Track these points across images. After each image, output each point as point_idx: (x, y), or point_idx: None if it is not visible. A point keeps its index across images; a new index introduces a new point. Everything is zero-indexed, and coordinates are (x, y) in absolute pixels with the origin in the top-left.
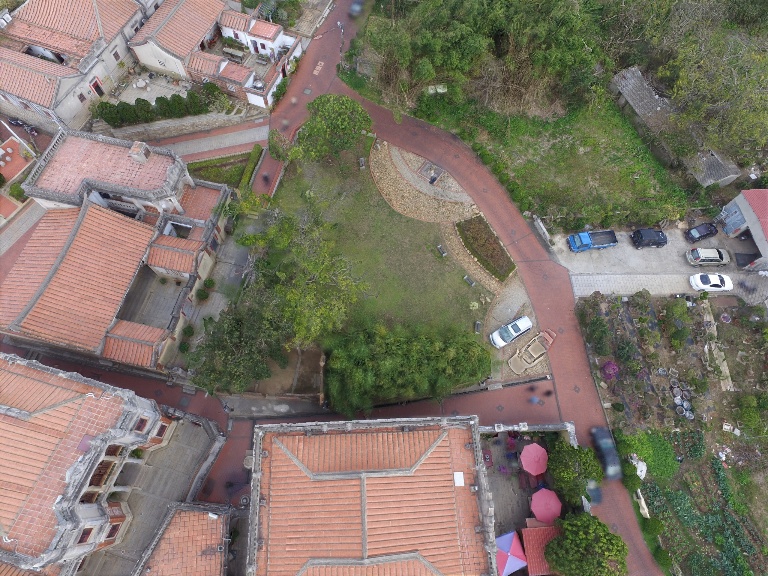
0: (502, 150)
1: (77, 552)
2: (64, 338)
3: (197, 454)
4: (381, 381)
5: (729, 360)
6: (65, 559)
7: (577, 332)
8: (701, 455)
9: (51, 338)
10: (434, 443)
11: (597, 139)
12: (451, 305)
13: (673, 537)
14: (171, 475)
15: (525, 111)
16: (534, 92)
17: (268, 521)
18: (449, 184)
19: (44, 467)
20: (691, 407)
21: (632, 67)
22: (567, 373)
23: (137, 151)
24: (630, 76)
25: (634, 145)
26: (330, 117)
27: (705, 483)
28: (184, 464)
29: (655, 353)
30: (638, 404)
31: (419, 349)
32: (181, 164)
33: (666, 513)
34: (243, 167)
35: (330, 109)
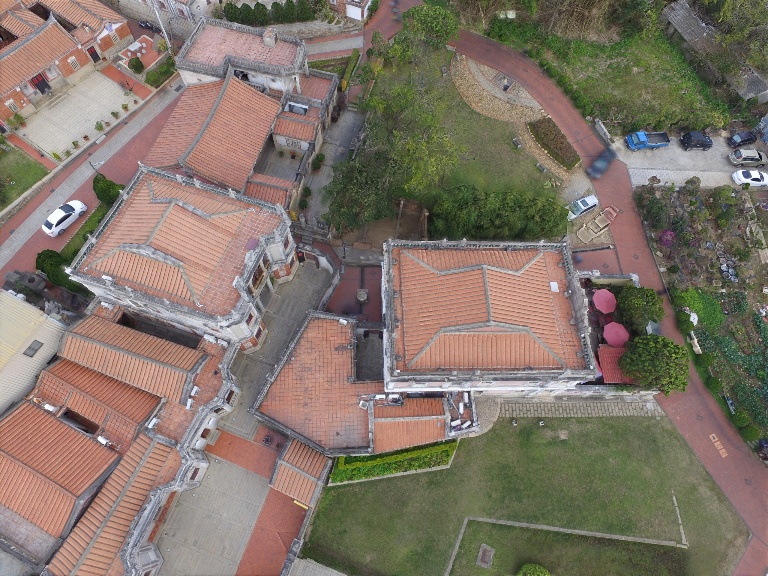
0: (565, 67)
1: (244, 330)
2: (217, 177)
3: (317, 289)
4: (481, 222)
5: (767, 240)
6: (233, 336)
7: (635, 213)
8: (745, 310)
9: (208, 175)
10: (534, 258)
11: (649, 61)
12: (526, 186)
13: (721, 371)
14: (296, 303)
15: (584, 36)
16: (596, 16)
17: (401, 308)
18: (520, 92)
19: (221, 257)
20: (736, 273)
21: (681, 0)
22: (627, 244)
23: (270, 35)
24: (679, 8)
25: (681, 68)
26: (426, 21)
27: (748, 333)
28: (306, 296)
29: (705, 227)
30: (690, 269)
31: (512, 199)
32: (305, 49)
33: (715, 353)
34: (343, 68)
35: (426, 14)
